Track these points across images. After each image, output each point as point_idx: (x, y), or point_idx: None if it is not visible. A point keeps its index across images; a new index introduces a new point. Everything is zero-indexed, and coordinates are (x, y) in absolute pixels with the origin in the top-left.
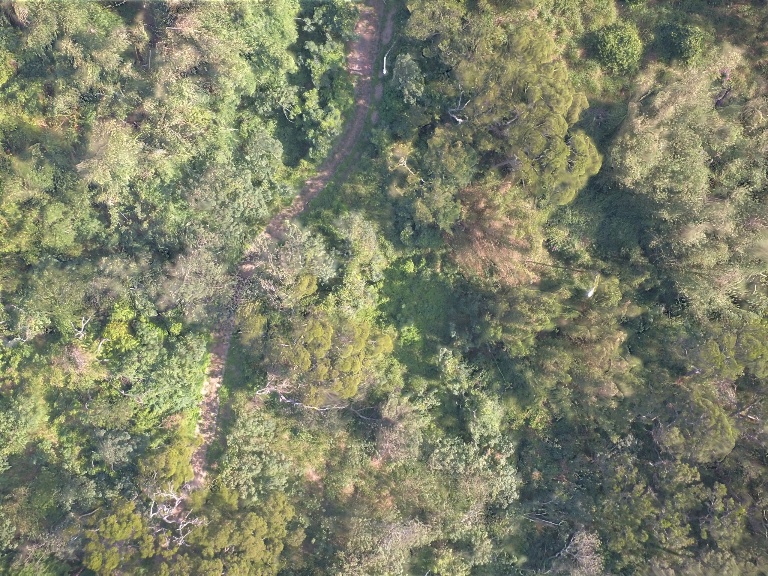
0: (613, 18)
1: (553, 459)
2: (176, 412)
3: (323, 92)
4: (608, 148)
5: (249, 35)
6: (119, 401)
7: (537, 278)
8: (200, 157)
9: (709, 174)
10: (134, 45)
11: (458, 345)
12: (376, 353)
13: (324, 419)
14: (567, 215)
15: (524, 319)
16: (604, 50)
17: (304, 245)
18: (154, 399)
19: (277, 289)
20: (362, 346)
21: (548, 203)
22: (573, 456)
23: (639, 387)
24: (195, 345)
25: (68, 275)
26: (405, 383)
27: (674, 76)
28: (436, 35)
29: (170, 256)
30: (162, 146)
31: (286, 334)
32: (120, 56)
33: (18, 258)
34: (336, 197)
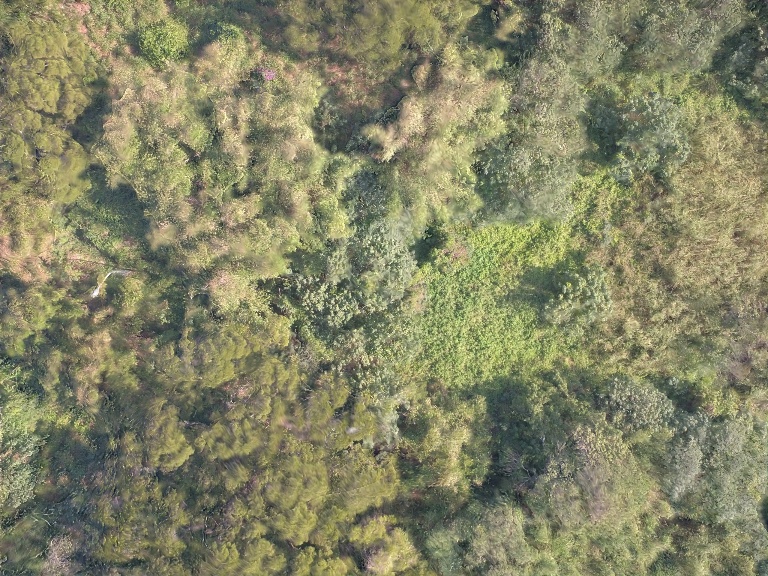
0: (162, 14)
1: (85, 459)
2: None
3: None
4: None
5: None
6: None
7: (87, 276)
8: None
9: (186, 174)
10: None
11: None
12: None
13: None
14: (102, 213)
15: (12, 316)
16: (143, 47)
17: None
18: None
19: None
20: None
21: (48, 200)
22: (102, 457)
23: (134, 388)
24: None
25: None
26: None
27: (218, 74)
28: None
29: None
30: None
31: None
32: None
33: None
34: None
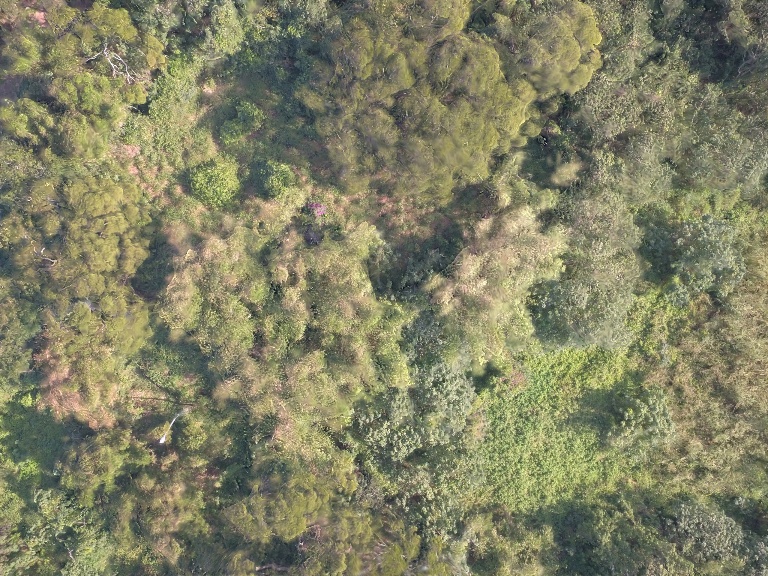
0: (211, 153)
1: None
2: None
3: None
4: None
5: None
6: None
7: (148, 412)
8: None
9: (249, 329)
10: None
11: None
12: None
13: None
14: (162, 354)
15: (82, 471)
16: (196, 188)
17: None
18: None
19: None
20: None
21: (112, 353)
22: None
23: (204, 536)
24: None
25: None
26: (22, 517)
27: (270, 211)
28: (9, 184)
29: None
30: None
31: None
32: None
33: None
34: None
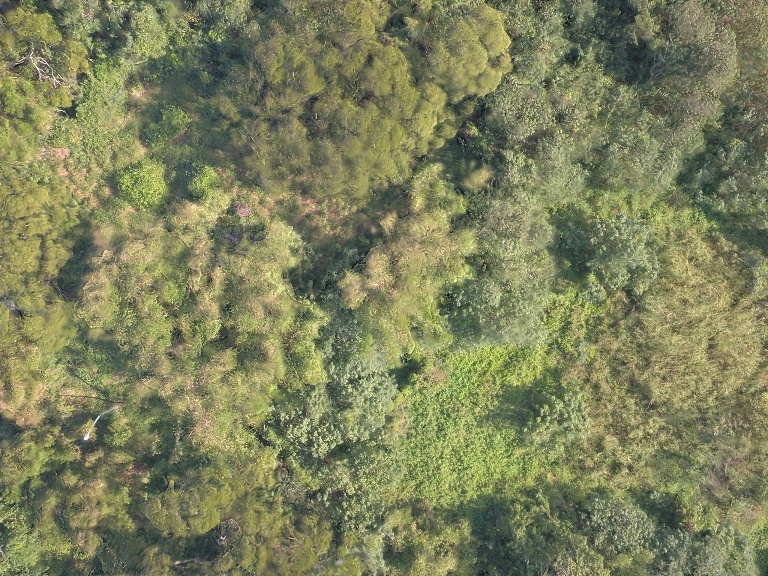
0: (139, 156)
1: None
2: None
3: None
4: None
5: None
6: None
7: (79, 410)
8: None
9: (166, 327)
10: None
11: None
12: None
13: None
14: (90, 353)
15: (6, 468)
16: (122, 190)
17: None
18: None
19: None
20: None
21: (36, 351)
22: None
23: (126, 531)
24: None
25: None
26: None
27: (195, 212)
28: None
29: None
30: None
31: None
32: None
33: None
34: None
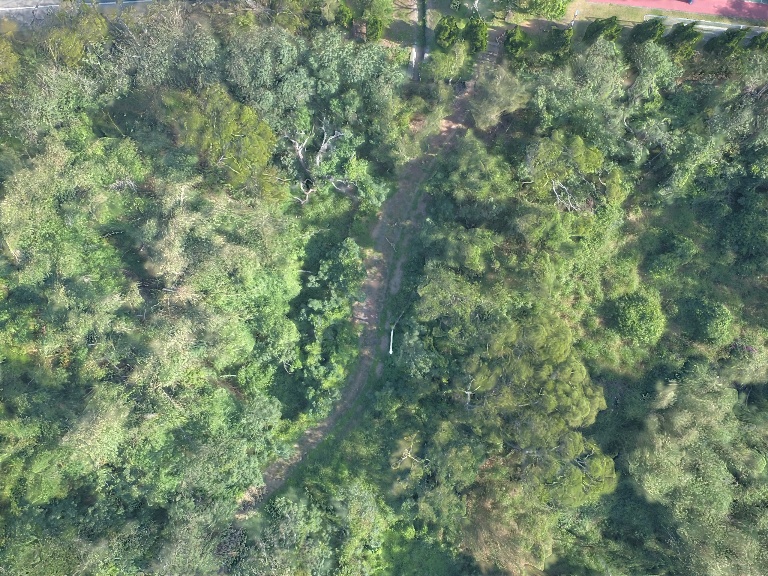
0: (635, 286)
1: None
2: None
3: (326, 343)
4: (625, 443)
5: (250, 296)
6: None
7: None
8: (194, 418)
9: (733, 497)
10: (128, 302)
11: None
12: None
13: None
14: None
15: None
16: (625, 325)
17: (300, 523)
18: None
19: None
20: None
21: (559, 506)
22: None
23: None
24: None
25: (52, 528)
26: None
27: (698, 352)
28: (447, 316)
29: None
30: (154, 409)
31: None
32: (113, 314)
33: (2, 496)
34: (336, 453)
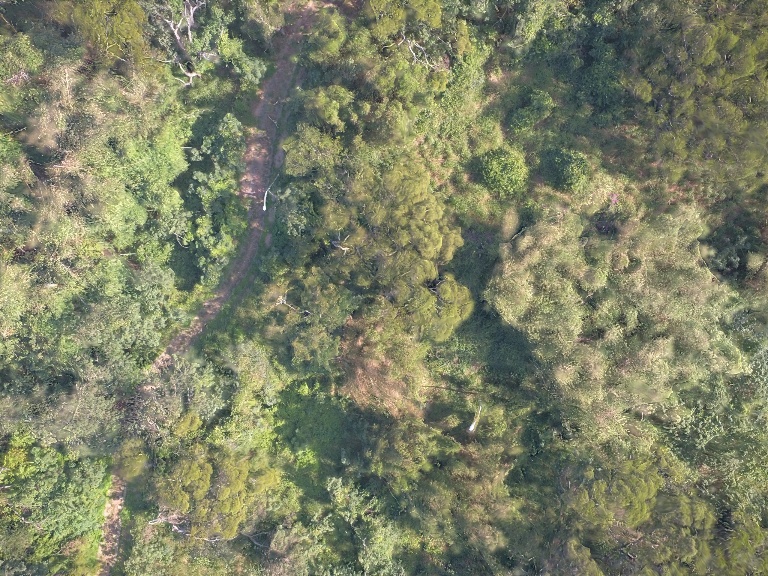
0: (499, 142)
1: None
2: (76, 537)
3: (217, 217)
4: (488, 281)
5: (136, 170)
6: (20, 528)
7: (430, 401)
8: (92, 289)
9: (580, 315)
10: (24, 182)
11: (350, 471)
12: (256, 492)
13: (215, 549)
14: (454, 342)
15: (401, 458)
16: (488, 176)
17: (192, 377)
18: (53, 525)
19: (161, 427)
20: (240, 488)
21: (425, 340)
22: None
23: (519, 523)
24: (91, 473)
25: None
26: (301, 506)
27: (561, 200)
28: (314, 171)
29: (73, 378)
30: (53, 280)
31: (173, 468)
32: (11, 193)
33: None
34: (231, 320)
